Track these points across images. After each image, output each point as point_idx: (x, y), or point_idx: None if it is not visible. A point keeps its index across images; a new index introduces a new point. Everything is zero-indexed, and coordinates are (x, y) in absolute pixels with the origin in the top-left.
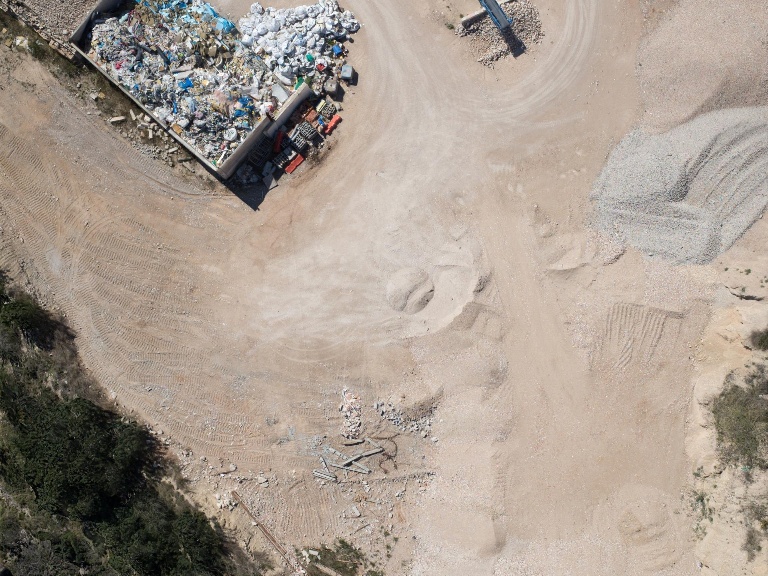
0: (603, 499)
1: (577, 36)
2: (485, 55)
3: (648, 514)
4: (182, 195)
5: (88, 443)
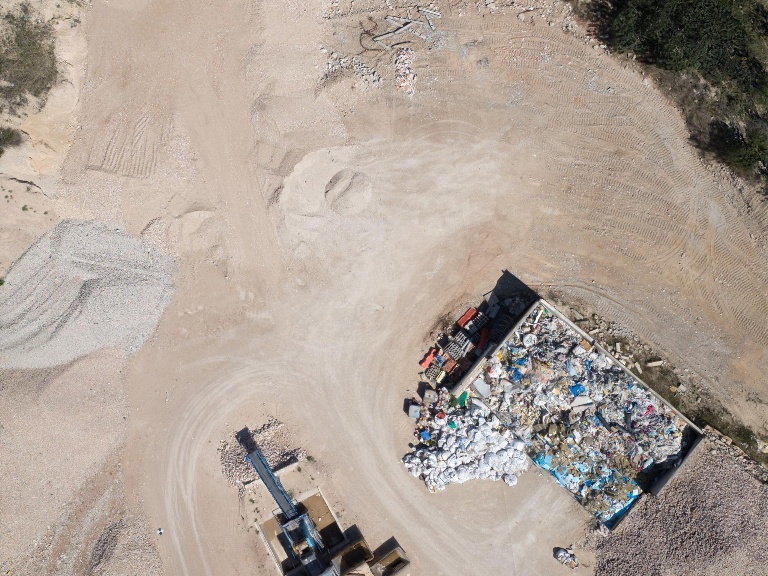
0: None
1: (185, 448)
2: (276, 430)
3: None
4: (583, 285)
5: (663, 22)
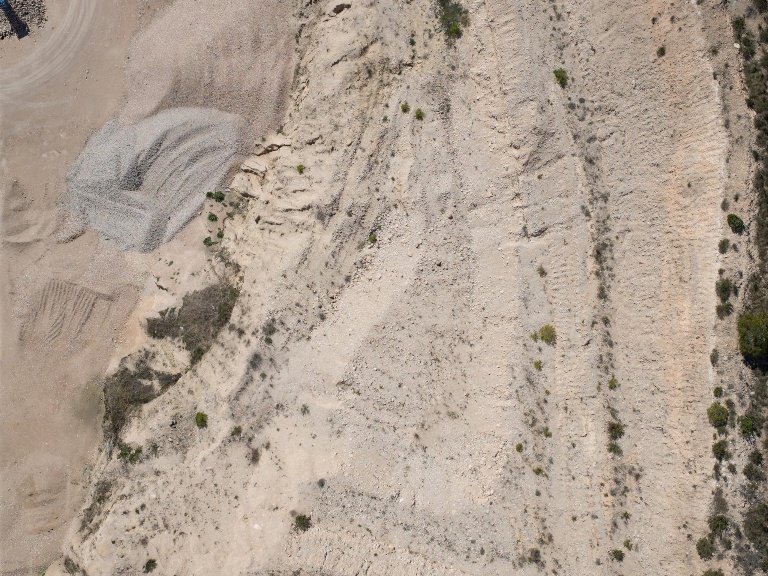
0: (11, 462)
1: (76, 24)
2: None
3: (45, 481)
4: None
5: None
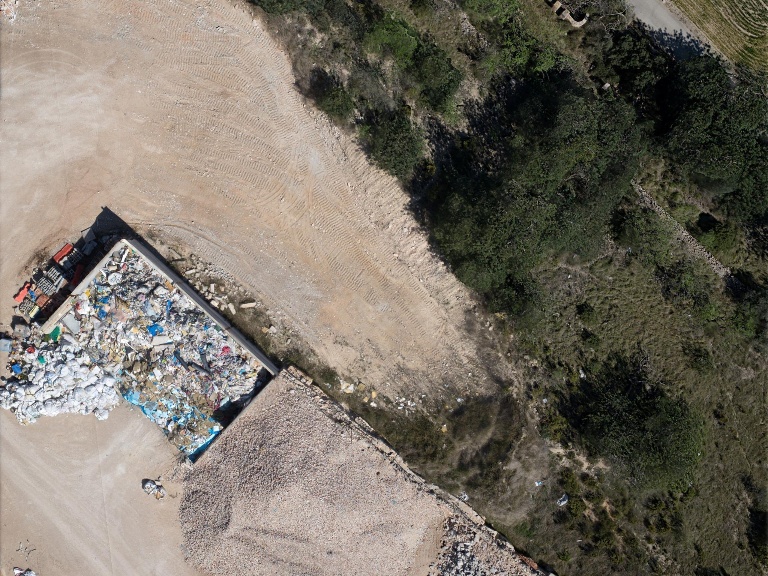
0: None
1: None
2: None
3: None
4: (183, 225)
5: None
